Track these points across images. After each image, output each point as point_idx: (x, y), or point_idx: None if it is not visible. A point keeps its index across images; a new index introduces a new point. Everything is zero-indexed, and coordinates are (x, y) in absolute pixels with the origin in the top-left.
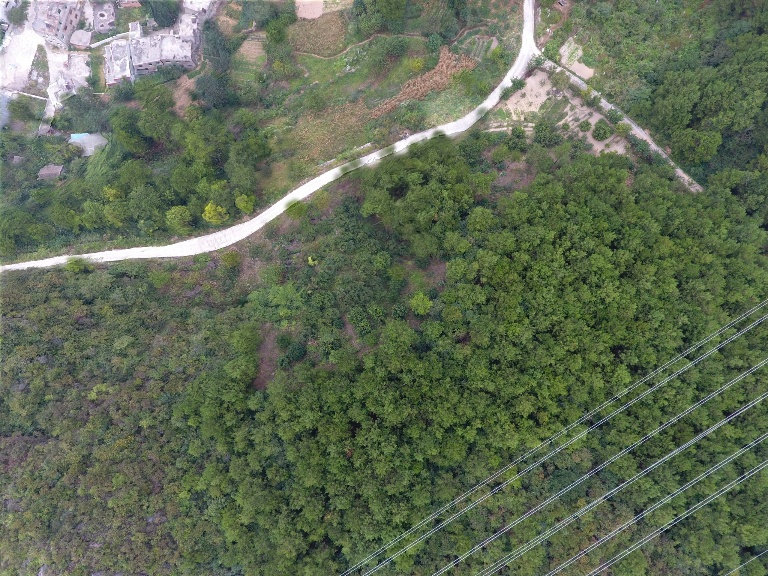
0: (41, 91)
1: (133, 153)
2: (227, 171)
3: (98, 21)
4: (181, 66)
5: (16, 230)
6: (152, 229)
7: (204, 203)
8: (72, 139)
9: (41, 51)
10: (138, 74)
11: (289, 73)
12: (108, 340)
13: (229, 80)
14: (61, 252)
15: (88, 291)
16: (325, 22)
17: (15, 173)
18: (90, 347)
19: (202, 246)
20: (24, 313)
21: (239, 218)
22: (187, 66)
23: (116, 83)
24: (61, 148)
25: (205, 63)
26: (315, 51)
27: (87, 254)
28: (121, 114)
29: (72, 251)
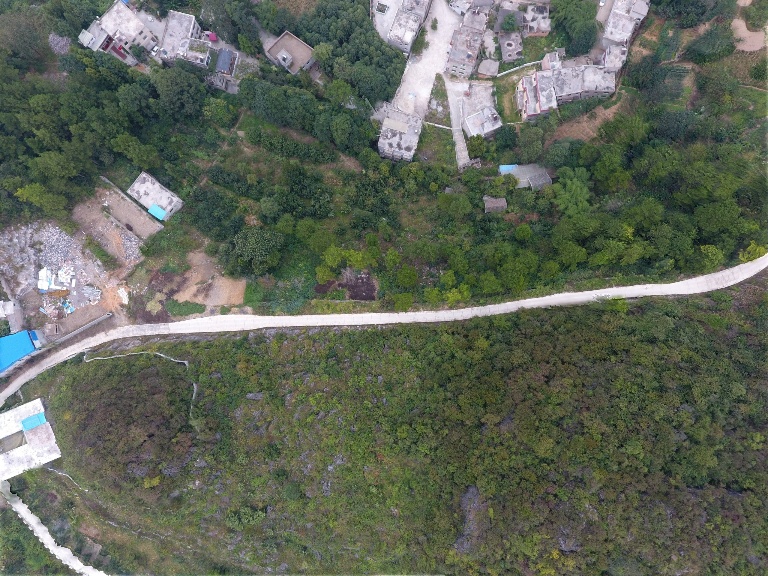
0: (444, 120)
1: (635, 190)
2: (764, 211)
3: (506, 51)
4: (597, 96)
5: (531, 268)
6: (670, 268)
7: (741, 243)
8: (502, 170)
9: (440, 80)
10: (559, 105)
11: (733, 106)
12: (723, 386)
13: (661, 112)
14: (564, 289)
15: (660, 334)
16: (767, 55)
17: (458, 205)
18: (713, 394)
19: (709, 284)
20: (623, 358)
21: (759, 257)
22: (600, 96)
23: (543, 114)
24: (507, 181)
25: (621, 94)
26: (758, 84)
27: (588, 291)
28: (591, 149)
29: (571, 288)
